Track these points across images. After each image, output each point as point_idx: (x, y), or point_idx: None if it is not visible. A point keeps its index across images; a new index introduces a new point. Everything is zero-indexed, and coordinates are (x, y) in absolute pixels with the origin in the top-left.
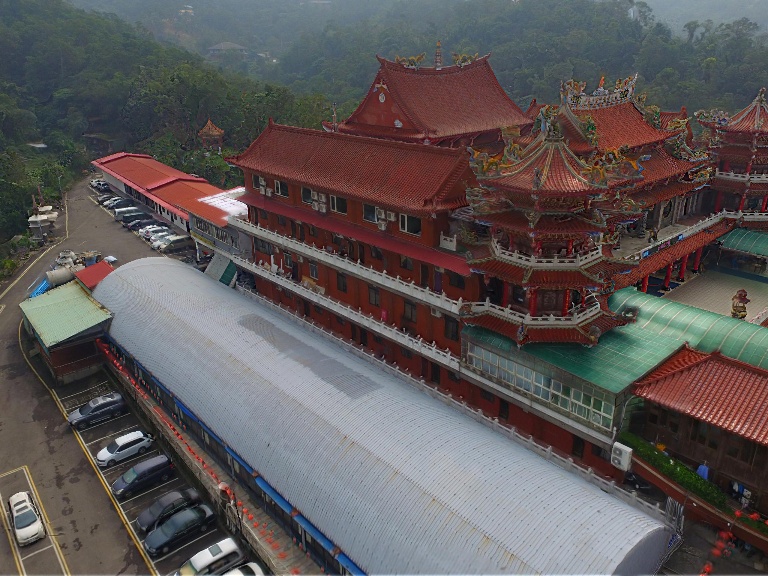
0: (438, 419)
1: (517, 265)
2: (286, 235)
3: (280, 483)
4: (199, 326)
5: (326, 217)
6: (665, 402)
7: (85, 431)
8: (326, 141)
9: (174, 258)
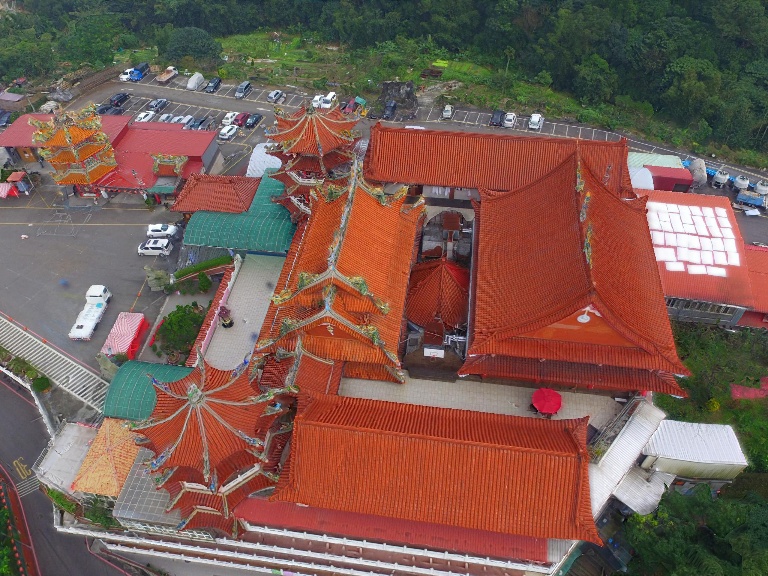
0: None
1: None
2: None
3: None
4: None
5: None
6: (250, 177)
7: None
8: None
9: None
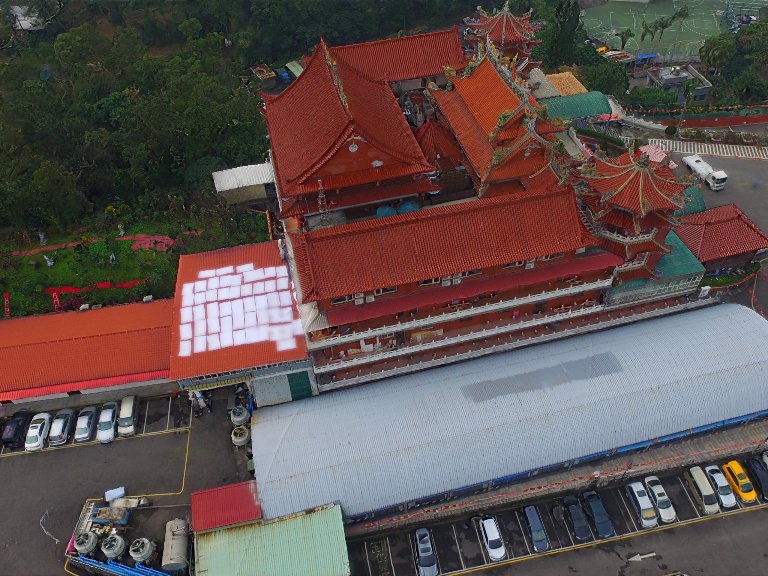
0: (656, 342)
1: (644, 242)
2: (416, 319)
3: (639, 438)
4: (458, 431)
5: (459, 285)
6: (712, 258)
7: (442, 569)
8: (414, 228)
9: (162, 427)
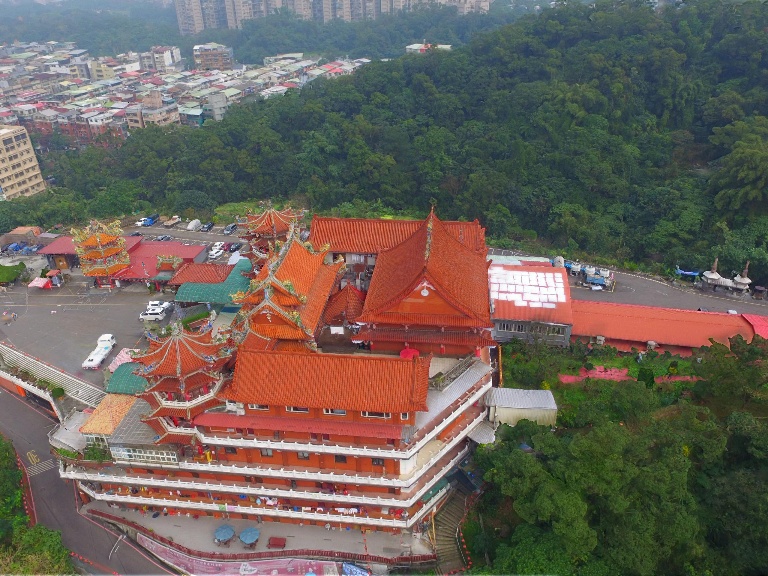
0: None
1: None
2: None
3: None
4: None
5: None
6: None
7: None
8: None
9: None
